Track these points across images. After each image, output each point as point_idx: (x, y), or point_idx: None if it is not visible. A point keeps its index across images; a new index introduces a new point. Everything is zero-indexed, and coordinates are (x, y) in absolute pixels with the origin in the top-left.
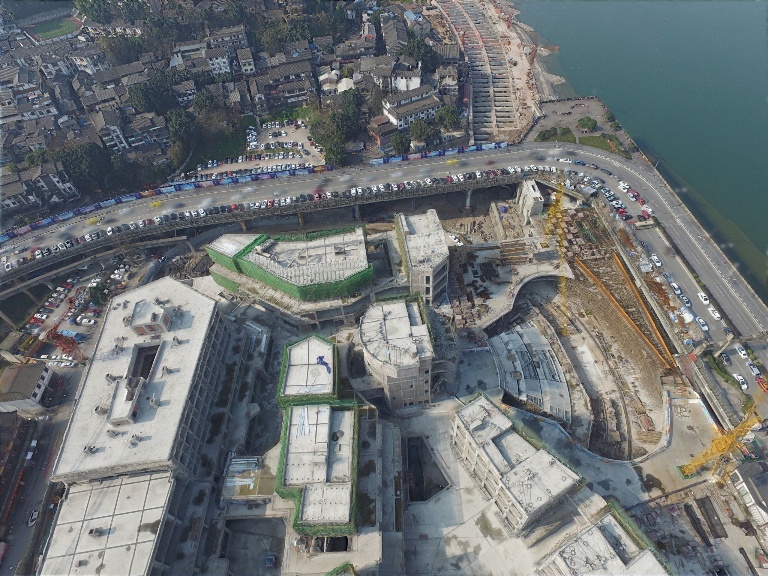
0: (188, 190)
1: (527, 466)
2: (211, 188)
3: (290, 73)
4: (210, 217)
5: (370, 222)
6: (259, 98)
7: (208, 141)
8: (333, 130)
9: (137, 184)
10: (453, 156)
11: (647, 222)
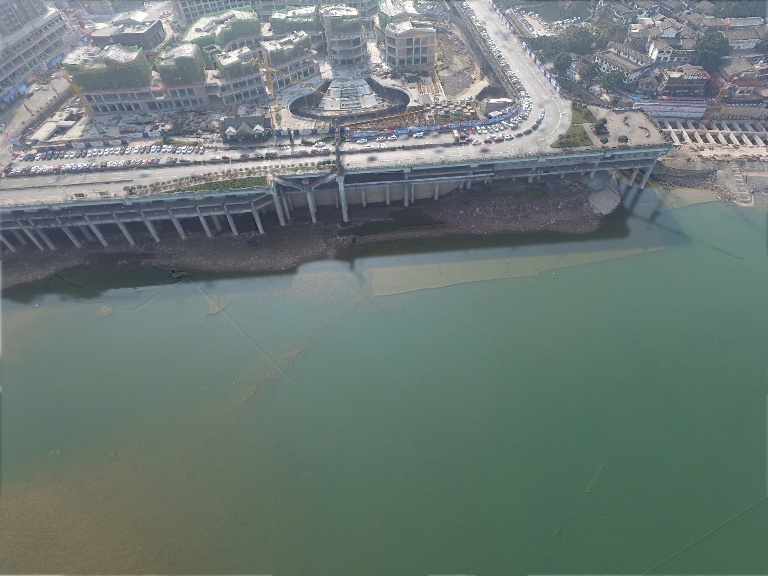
0: (487, 1)
1: (278, 45)
2: (490, 6)
3: (636, 1)
4: (460, 7)
5: (481, 68)
6: (601, 3)
7: (551, 5)
8: (571, 35)
9: (508, 0)
10: (540, 73)
11: (456, 133)
